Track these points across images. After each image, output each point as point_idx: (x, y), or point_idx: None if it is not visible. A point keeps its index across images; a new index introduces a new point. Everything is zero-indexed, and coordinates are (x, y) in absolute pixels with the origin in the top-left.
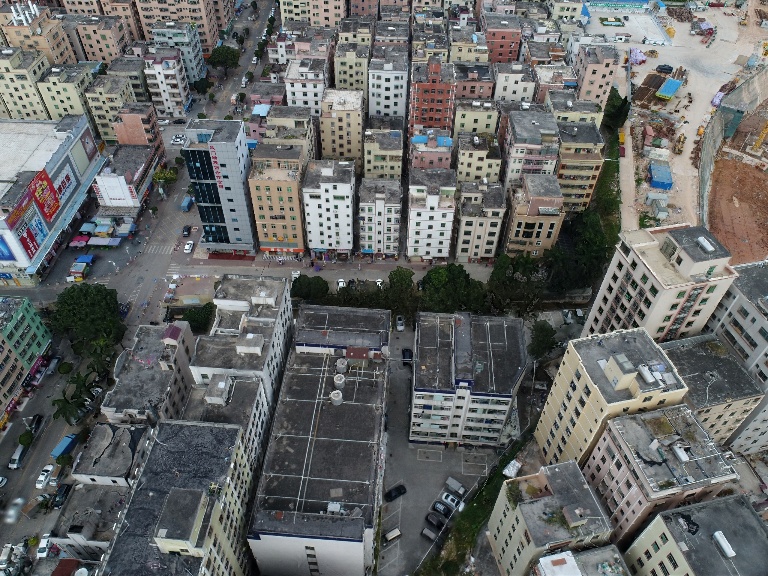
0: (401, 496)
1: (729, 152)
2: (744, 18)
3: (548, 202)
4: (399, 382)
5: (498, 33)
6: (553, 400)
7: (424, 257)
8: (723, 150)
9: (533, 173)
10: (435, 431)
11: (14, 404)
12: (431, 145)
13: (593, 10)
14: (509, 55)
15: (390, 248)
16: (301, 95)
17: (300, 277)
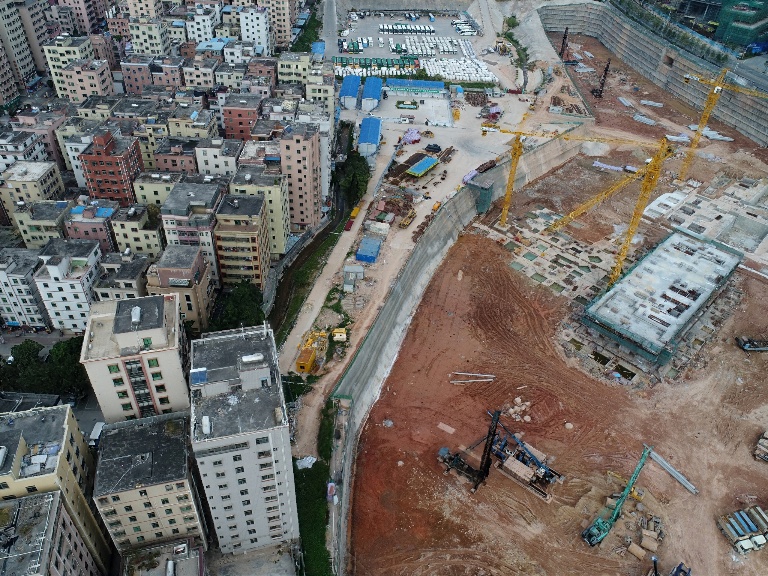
0: None
1: (477, 227)
2: (532, 104)
3: (176, 273)
4: None
5: (234, 111)
6: None
7: (73, 330)
8: (472, 225)
9: (191, 244)
10: None
11: None
12: (87, 216)
13: (394, 94)
14: (250, 132)
15: (35, 320)
16: (4, 166)
17: None
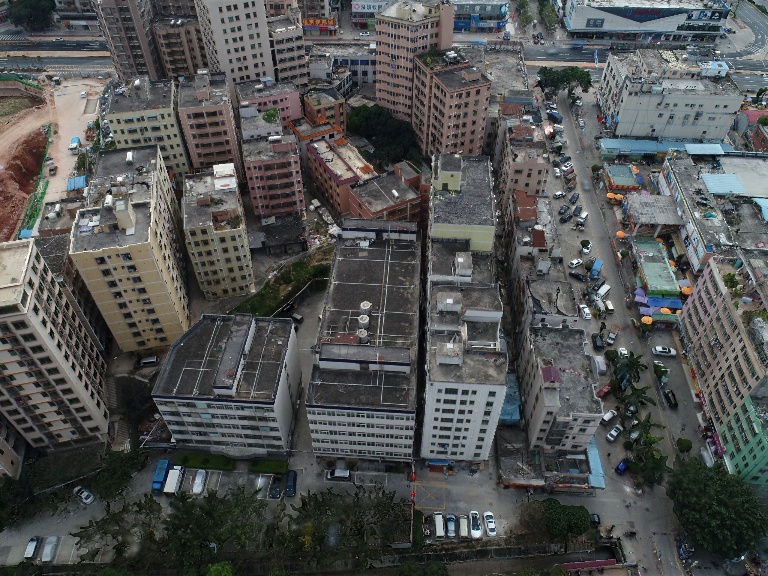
0: None
1: None
2: None
3: None
4: None
5: None
6: None
7: None
8: None
9: None
10: None
11: None
12: None
13: None
14: None
15: None
16: None
17: (438, 570)
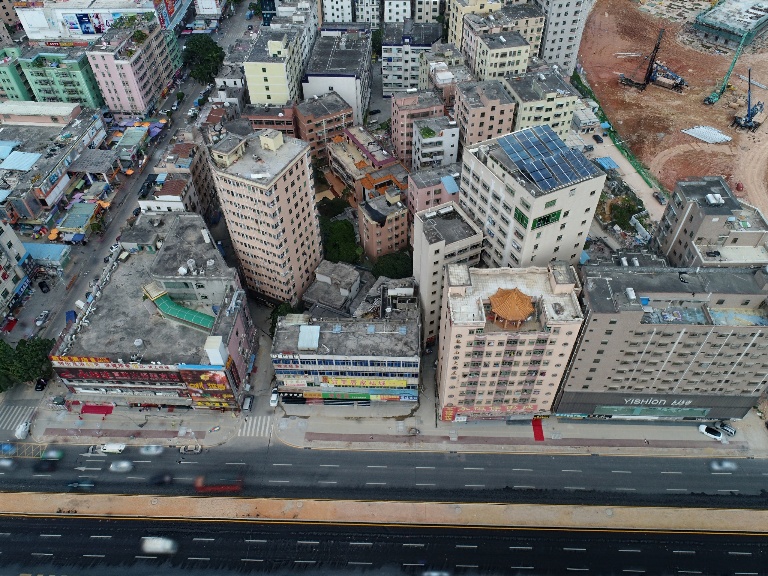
0: (378, 113)
1: None
2: None
3: None
4: (379, 79)
5: None
6: (449, 38)
7: None
8: None
9: None
10: (396, 82)
11: (168, 88)
12: None
13: None
14: None
15: (375, 25)
16: None
17: None
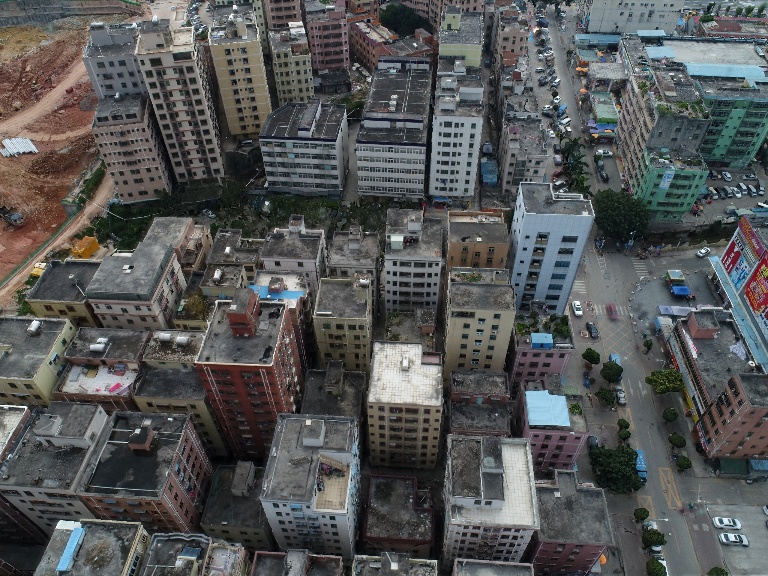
0: None
1: None
2: None
3: None
4: (352, 199)
5: None
6: None
7: None
8: None
9: None
10: None
11: None
12: None
13: None
14: None
15: None
16: None
17: None
